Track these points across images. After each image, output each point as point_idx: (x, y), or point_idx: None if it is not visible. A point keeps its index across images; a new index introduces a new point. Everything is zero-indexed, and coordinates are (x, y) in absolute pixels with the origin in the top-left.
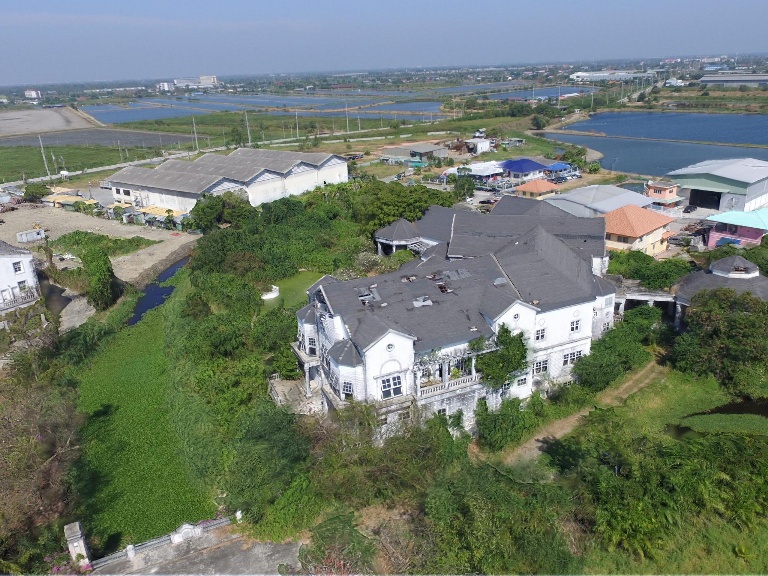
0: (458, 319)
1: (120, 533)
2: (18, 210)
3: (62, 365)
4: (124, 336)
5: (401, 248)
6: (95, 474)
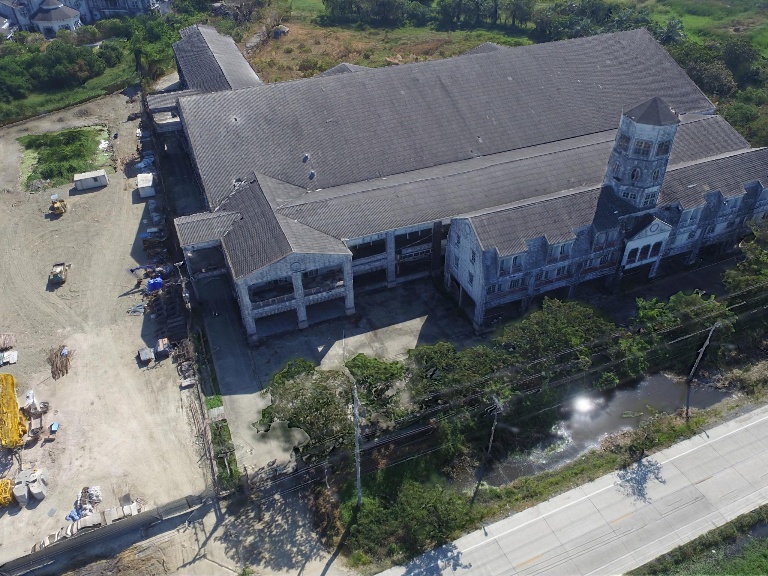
0: None
1: None
2: None
3: None
4: None
5: None
6: None
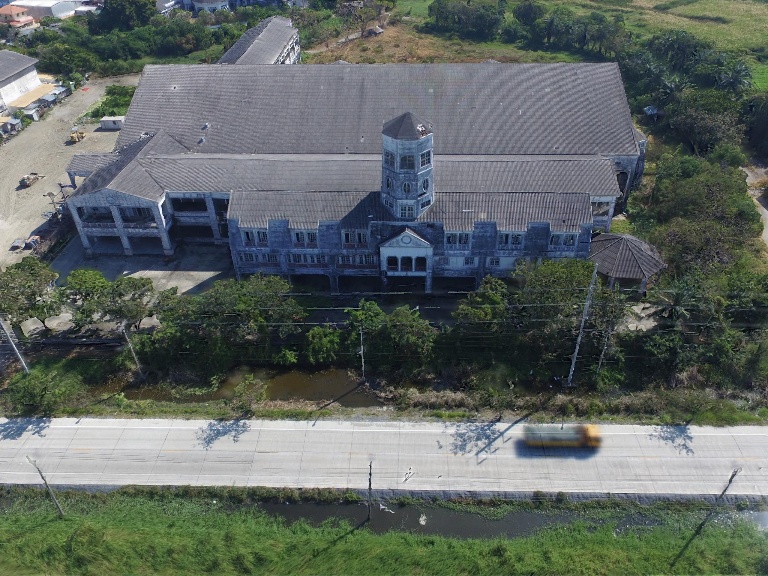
0: None
1: None
2: None
3: None
4: None
5: (168, 12)
6: None
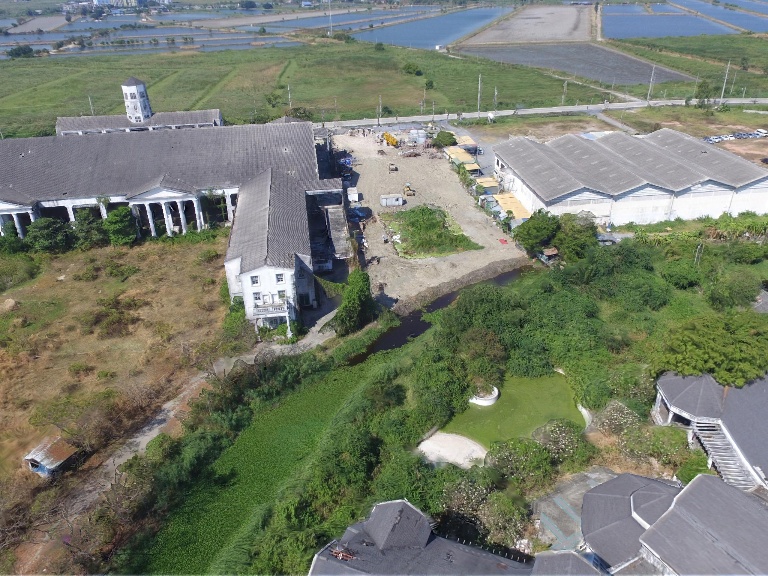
0: None
1: None
2: (420, 157)
3: (252, 397)
4: (330, 379)
5: (680, 420)
6: (146, 562)
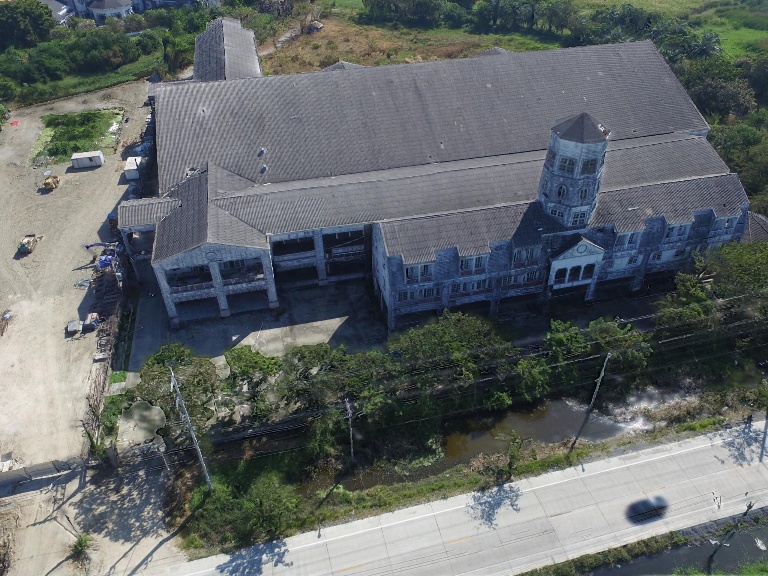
0: None
1: None
2: None
3: None
4: None
5: None
6: None
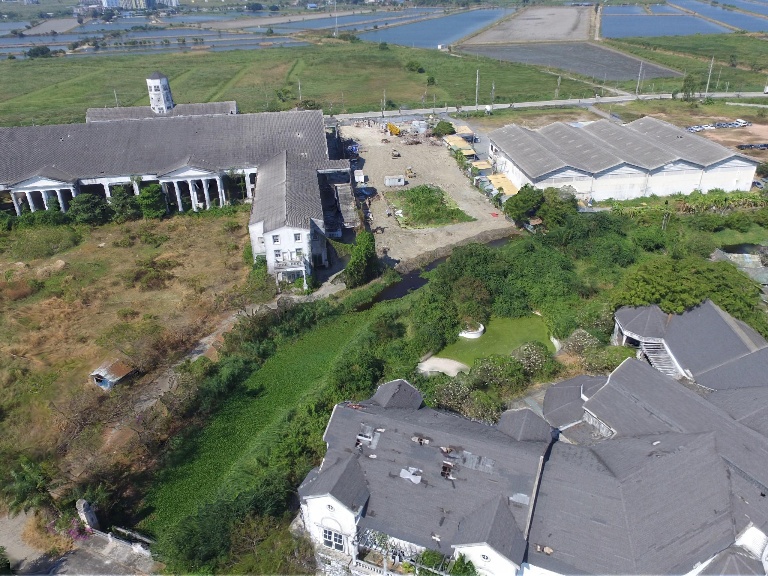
0: (430, 516)
1: (154, 508)
2: (421, 144)
3: (276, 333)
4: (341, 321)
5: (632, 342)
6: (195, 447)
